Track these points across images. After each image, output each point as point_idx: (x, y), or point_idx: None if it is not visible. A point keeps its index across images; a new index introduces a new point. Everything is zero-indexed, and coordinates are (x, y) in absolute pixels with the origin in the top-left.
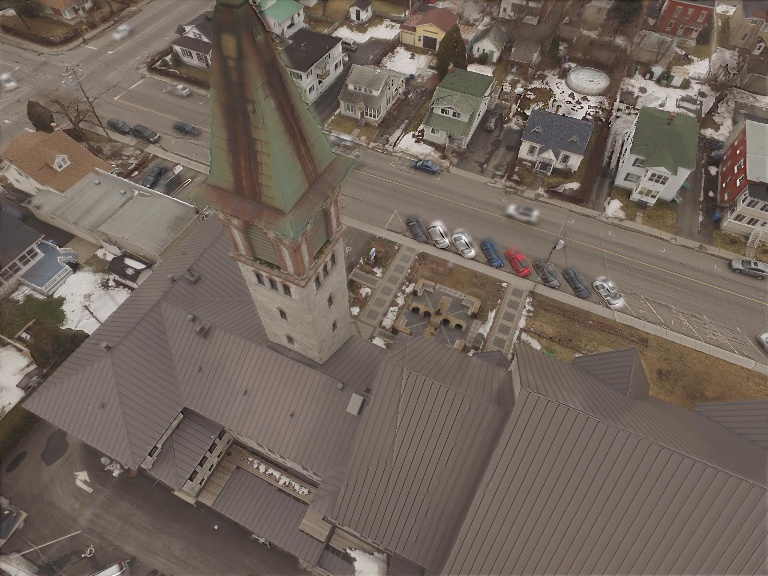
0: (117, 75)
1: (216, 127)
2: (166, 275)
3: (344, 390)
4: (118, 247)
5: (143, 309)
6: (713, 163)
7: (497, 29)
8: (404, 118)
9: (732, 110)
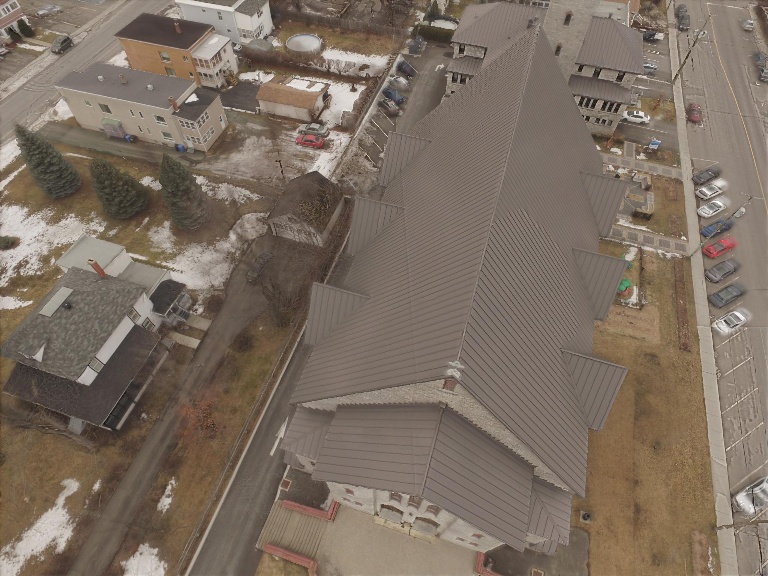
0: None
1: None
2: None
3: None
4: None
5: None
6: None
7: None
8: None
9: None
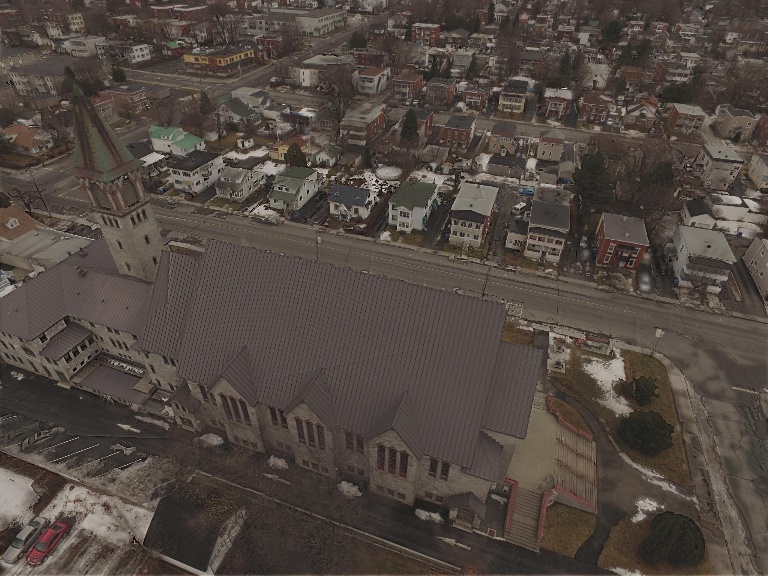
0: (64, 183)
1: (76, 141)
2: None
3: None
4: (44, 267)
5: None
6: None
7: (331, 147)
8: (261, 198)
9: None
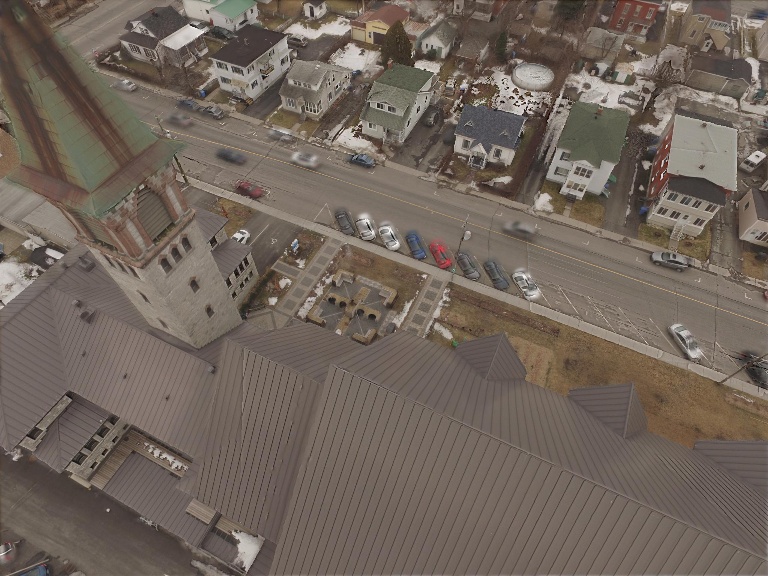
0: None
1: (10, 108)
2: None
3: (216, 373)
4: (42, 238)
5: (33, 295)
6: (647, 158)
7: (445, 25)
8: (346, 113)
9: (673, 106)
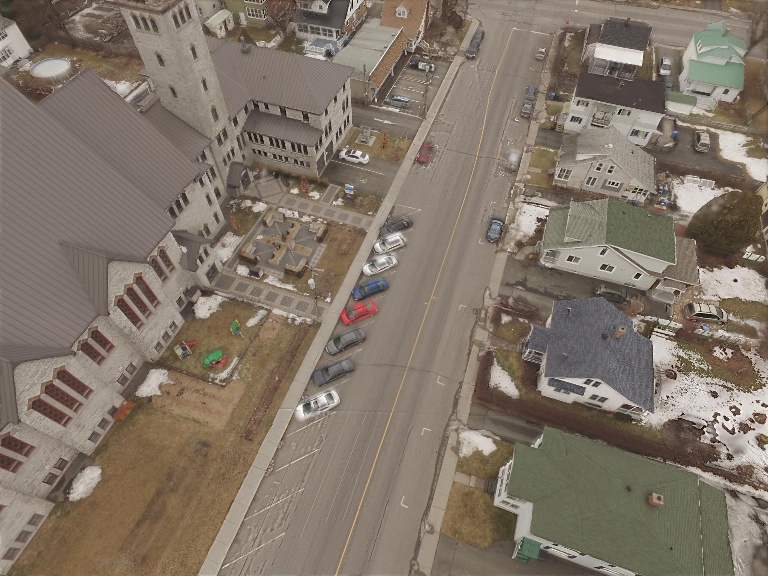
0: (546, 21)
1: None
2: None
3: None
4: None
5: None
6: None
7: None
8: None
9: None
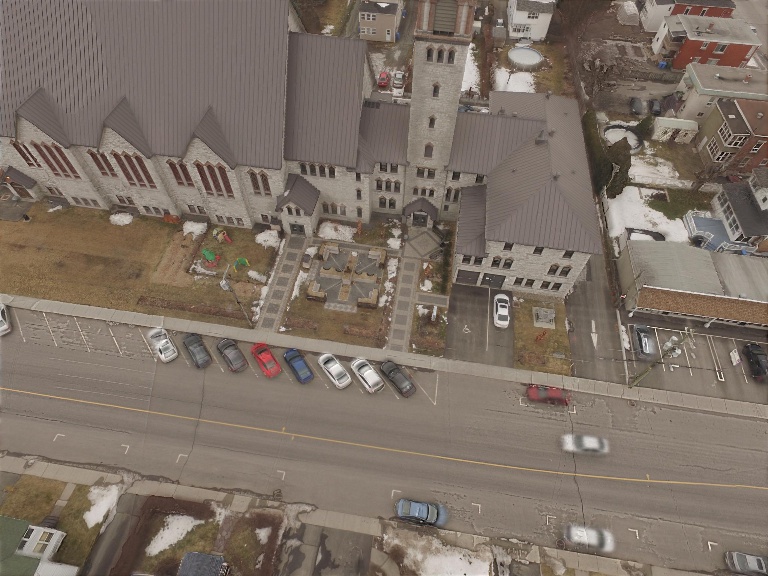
0: None
1: None
2: (567, 152)
3: None
4: None
5: None
6: None
7: None
8: None
9: None
